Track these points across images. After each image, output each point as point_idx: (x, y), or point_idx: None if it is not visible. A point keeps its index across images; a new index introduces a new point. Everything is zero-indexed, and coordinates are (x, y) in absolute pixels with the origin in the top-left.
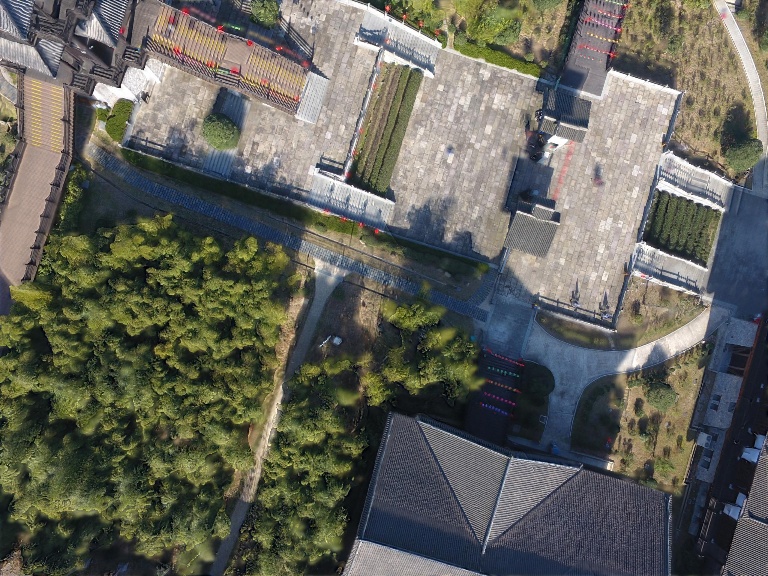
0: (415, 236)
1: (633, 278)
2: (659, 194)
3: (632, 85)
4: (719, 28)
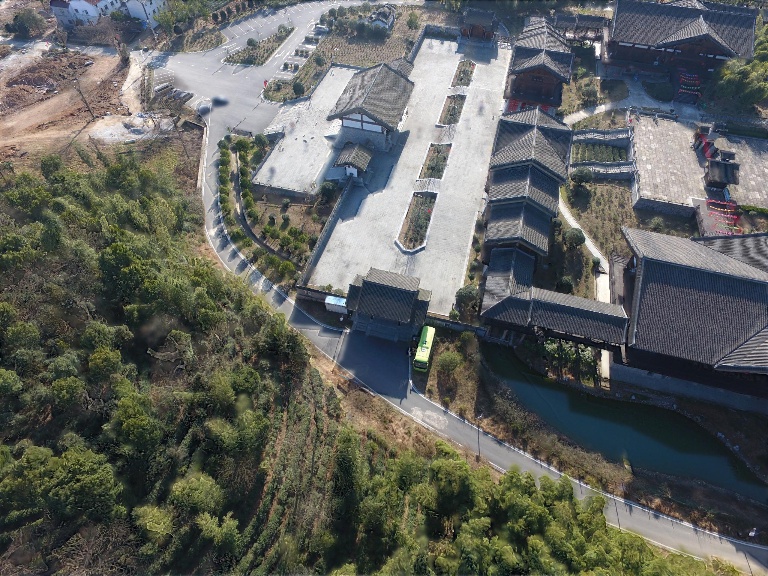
0: (762, 141)
1: None
2: None
3: None
4: None
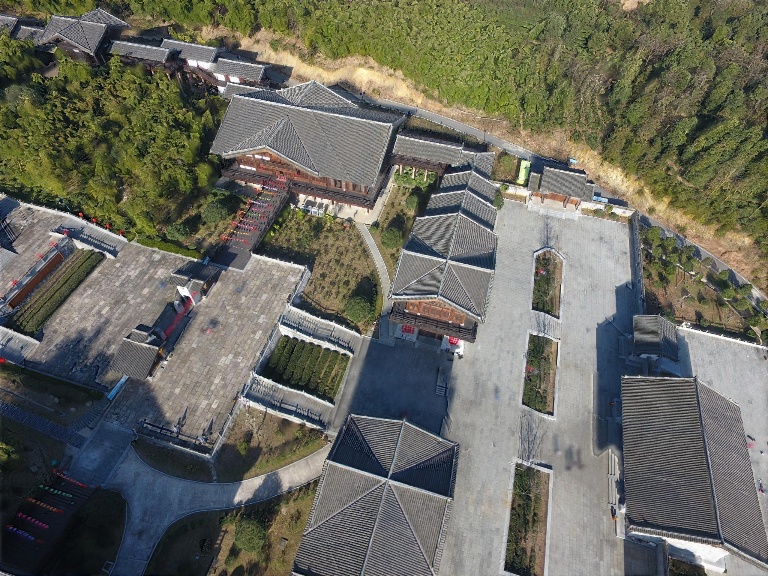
0: (46, 369)
1: (249, 409)
2: (288, 340)
3: (270, 263)
4: (357, 237)
